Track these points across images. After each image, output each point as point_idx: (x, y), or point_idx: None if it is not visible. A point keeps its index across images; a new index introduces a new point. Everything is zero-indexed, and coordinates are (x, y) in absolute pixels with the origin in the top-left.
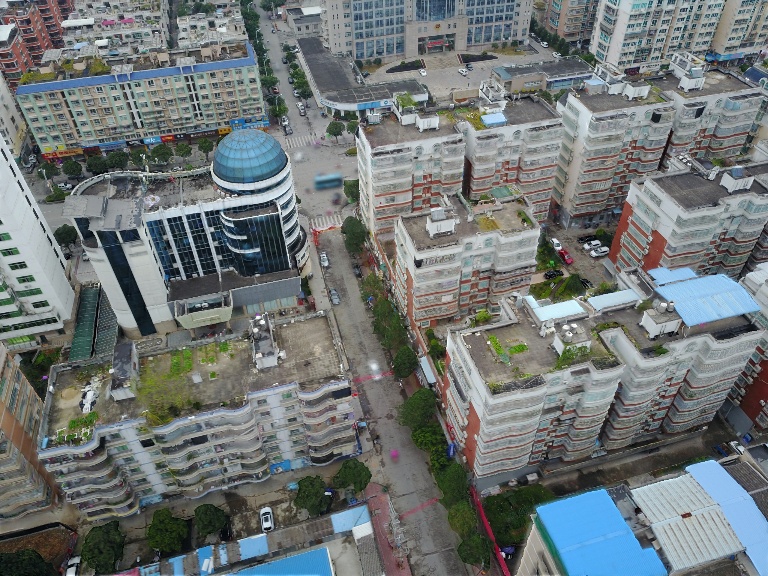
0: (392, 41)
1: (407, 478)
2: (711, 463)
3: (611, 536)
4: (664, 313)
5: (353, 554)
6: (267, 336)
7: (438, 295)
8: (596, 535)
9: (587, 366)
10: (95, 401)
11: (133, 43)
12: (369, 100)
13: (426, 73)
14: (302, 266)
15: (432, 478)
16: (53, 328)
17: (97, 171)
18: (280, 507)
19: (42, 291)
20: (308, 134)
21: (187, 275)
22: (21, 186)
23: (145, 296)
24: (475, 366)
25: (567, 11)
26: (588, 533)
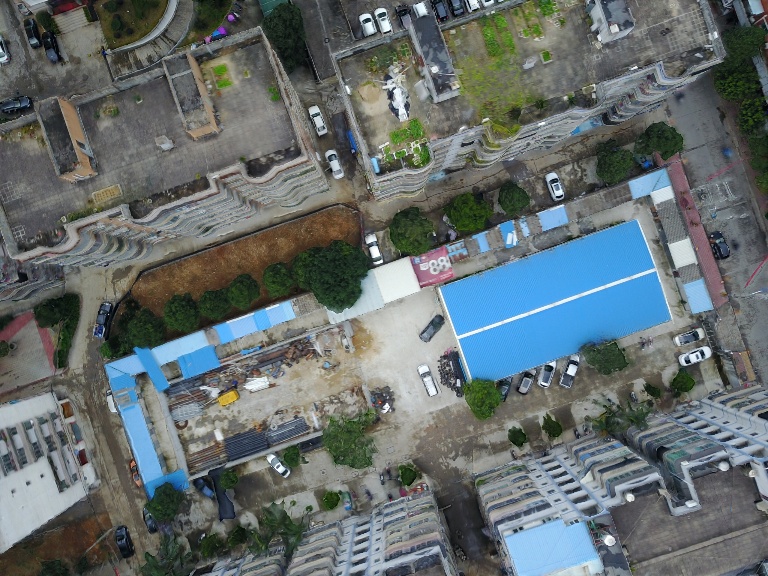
0: None
1: (697, 129)
2: None
3: None
4: None
5: (646, 215)
6: None
7: None
8: None
9: None
10: (408, 103)
11: None
12: None
13: None
14: None
15: (724, 127)
16: None
17: None
18: (563, 170)
19: None
20: None
21: None
22: None
23: None
24: None
25: None
26: None
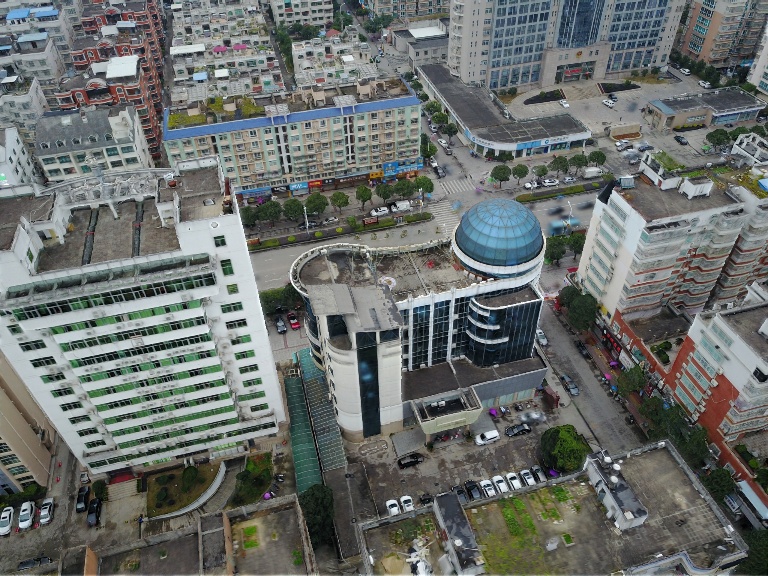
0: (528, 69)
1: None
2: None
3: None
4: None
5: None
6: (623, 484)
7: (763, 408)
8: None
9: None
10: None
11: (252, 73)
12: (527, 139)
13: (569, 105)
14: None
15: None
16: (268, 433)
17: (249, 224)
18: None
19: (265, 394)
20: (463, 177)
21: (414, 365)
22: None
23: (382, 397)
24: None
25: (716, 36)
26: None
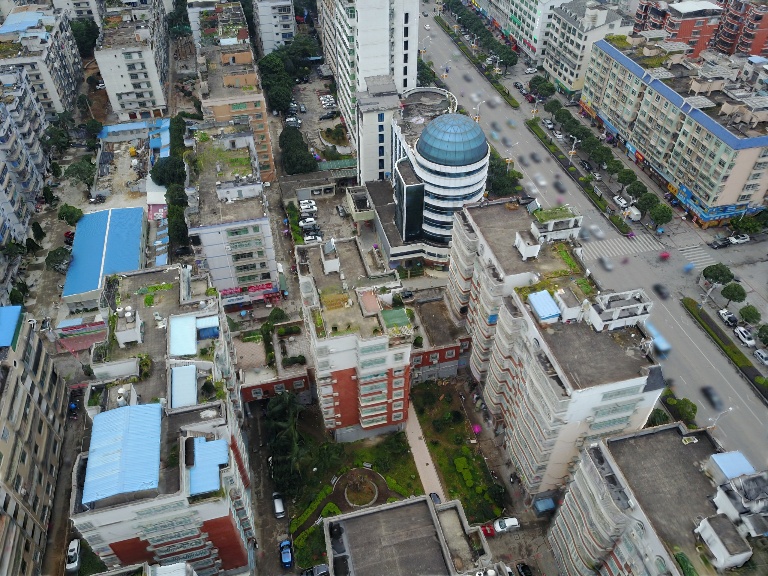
0: None
1: None
2: None
3: None
4: None
5: None
6: None
7: None
8: None
9: None
10: None
11: None
12: None
13: None
14: (427, 259)
15: None
16: None
17: (564, 129)
18: None
19: None
20: None
21: None
22: (407, 59)
23: None
24: None
25: None
26: None
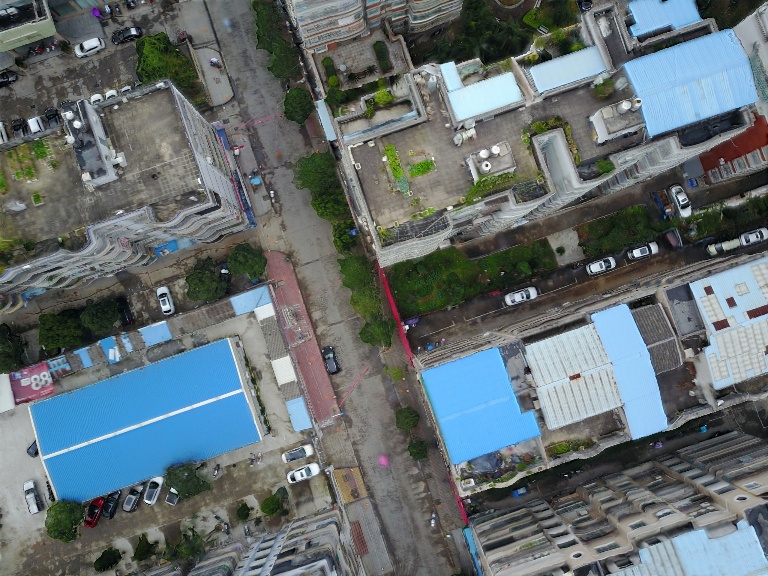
0: None
1: (311, 243)
2: (621, 309)
3: (492, 403)
4: (624, 114)
5: (259, 329)
6: (91, 141)
7: (332, 19)
8: (478, 402)
9: (506, 194)
10: None
11: None
12: None
13: None
14: None
15: None
16: None
17: None
18: (177, 284)
19: None
20: None
21: None
22: None
23: None
24: (363, 203)
25: None
26: (470, 401)
